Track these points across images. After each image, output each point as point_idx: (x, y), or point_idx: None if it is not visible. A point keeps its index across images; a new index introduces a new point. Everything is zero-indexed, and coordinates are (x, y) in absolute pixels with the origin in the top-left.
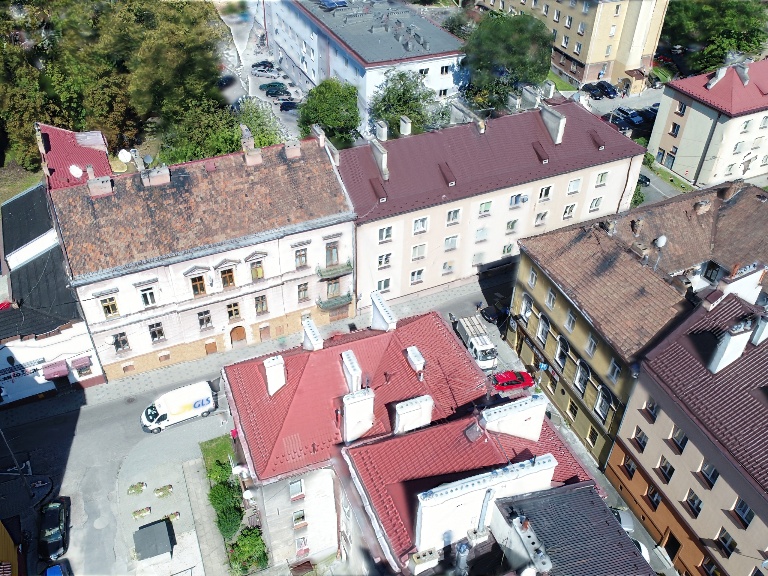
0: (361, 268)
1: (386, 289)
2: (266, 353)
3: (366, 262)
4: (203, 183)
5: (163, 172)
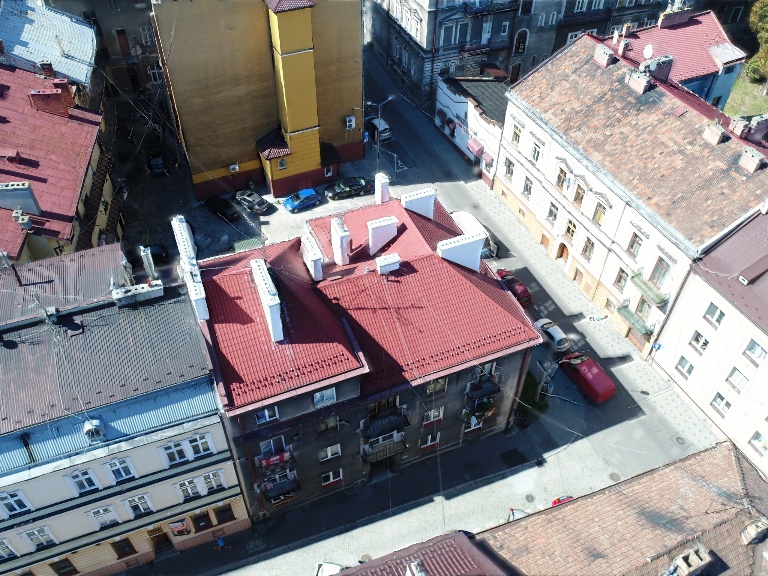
0: (675, 319)
1: (688, 375)
2: (559, 286)
3: (682, 319)
4: (656, 116)
5: (642, 80)
